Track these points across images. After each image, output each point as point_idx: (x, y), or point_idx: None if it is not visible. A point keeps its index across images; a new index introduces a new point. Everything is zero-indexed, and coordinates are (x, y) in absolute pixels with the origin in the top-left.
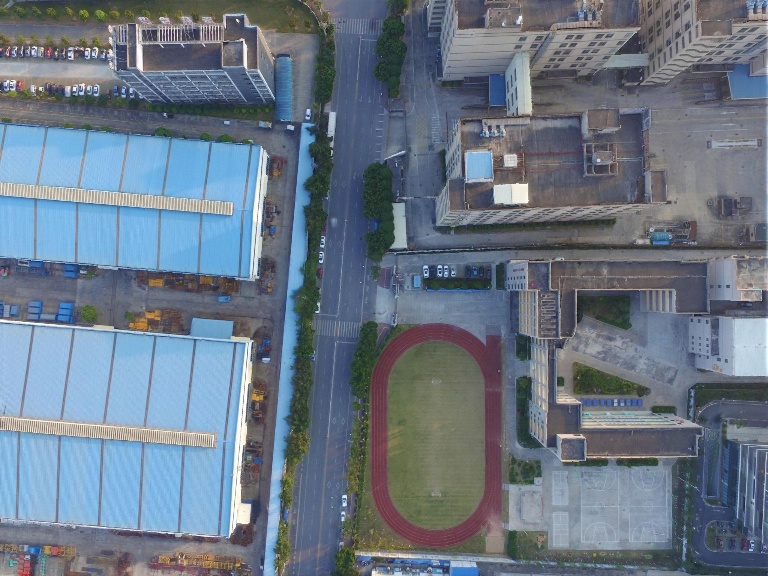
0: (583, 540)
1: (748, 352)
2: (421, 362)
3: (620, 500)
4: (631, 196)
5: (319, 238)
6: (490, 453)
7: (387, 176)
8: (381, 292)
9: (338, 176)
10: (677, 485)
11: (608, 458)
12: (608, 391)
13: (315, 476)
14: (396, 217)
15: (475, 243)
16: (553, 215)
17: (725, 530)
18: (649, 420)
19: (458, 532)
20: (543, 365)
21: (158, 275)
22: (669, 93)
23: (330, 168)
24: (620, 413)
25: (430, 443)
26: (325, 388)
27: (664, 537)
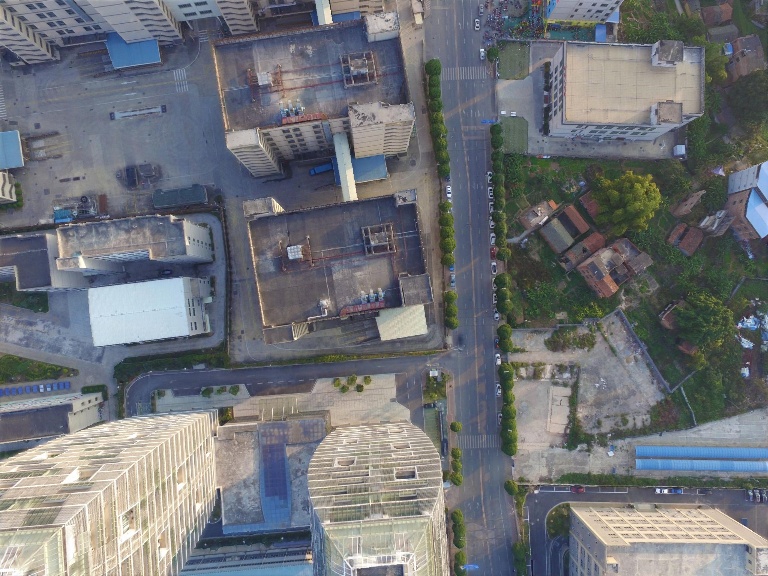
0: None
1: (105, 321)
2: None
3: None
4: None
5: None
6: None
7: None
8: None
9: None
10: None
11: None
12: (32, 377)
13: None
14: None
15: None
16: None
17: None
18: (48, 402)
19: None
20: None
21: None
22: (66, 69)
23: None
24: (45, 398)
25: None
26: None
27: None
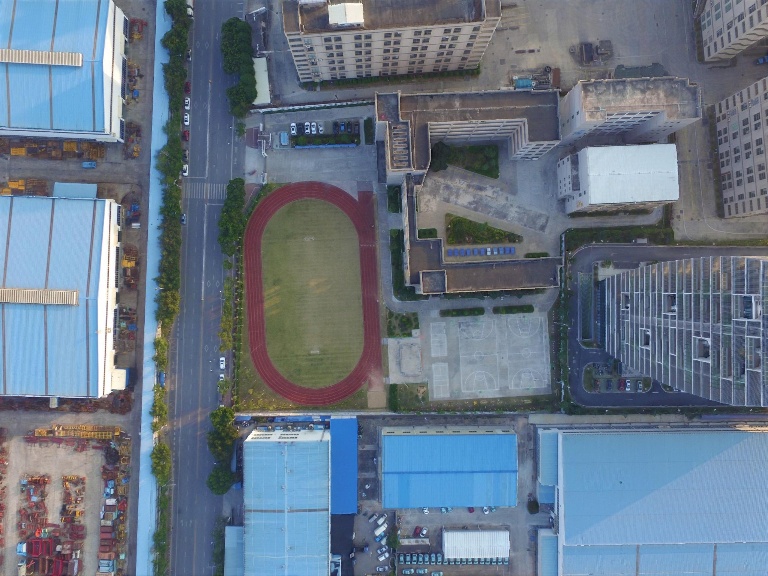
0: (464, 390)
1: (602, 179)
2: (294, 221)
3: (498, 348)
4: (469, 16)
5: (180, 95)
6: (367, 309)
7: (244, 28)
8: (250, 152)
9: (200, 37)
10: (553, 330)
11: (484, 307)
12: (481, 240)
13: (192, 340)
14: (258, 72)
15: (341, 99)
16: (406, 54)
17: (601, 371)
18: None
19: (339, 389)
20: (405, 206)
21: (20, 144)
22: None
23: (187, 23)
24: None
25: (307, 301)
26: (197, 251)
27: (543, 382)
